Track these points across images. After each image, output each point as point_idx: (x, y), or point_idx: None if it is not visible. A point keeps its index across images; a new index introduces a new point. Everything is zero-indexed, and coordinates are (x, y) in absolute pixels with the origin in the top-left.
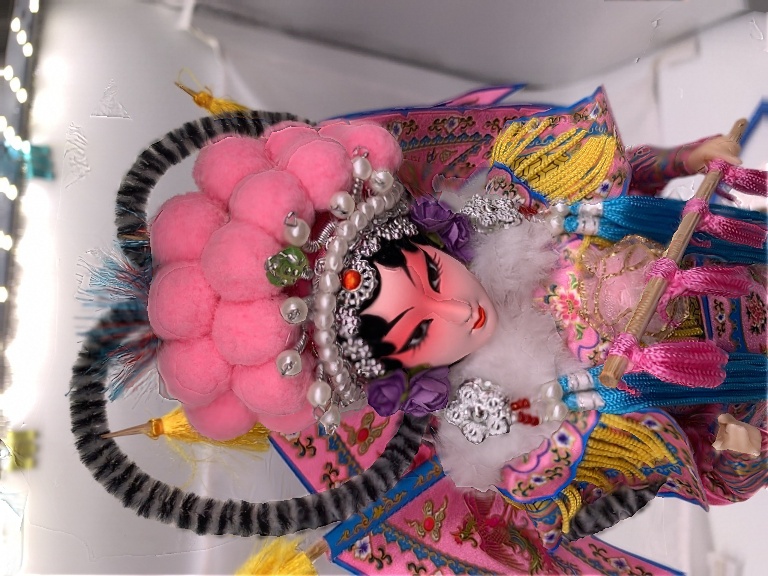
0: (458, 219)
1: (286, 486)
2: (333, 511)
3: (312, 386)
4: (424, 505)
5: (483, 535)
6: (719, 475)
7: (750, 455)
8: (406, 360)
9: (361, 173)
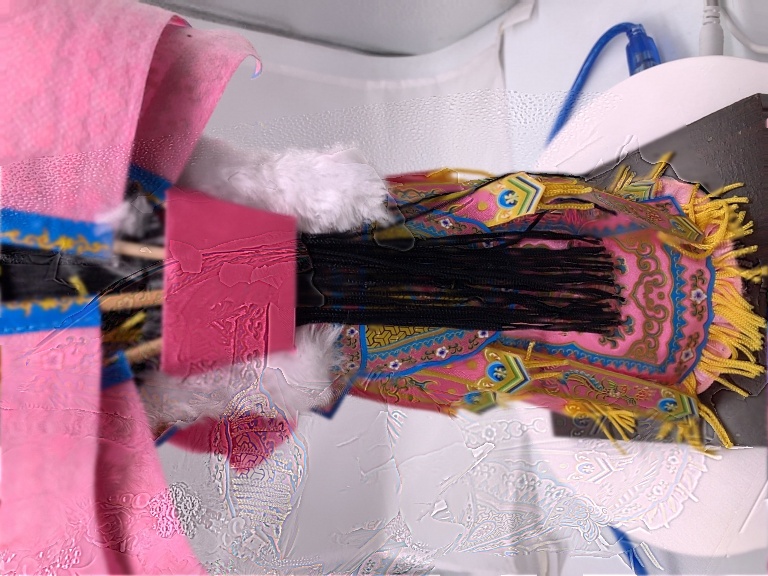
0: (131, 536)
1: None
2: None
3: None
4: None
5: None
6: None
7: None
8: None
9: (5, 572)
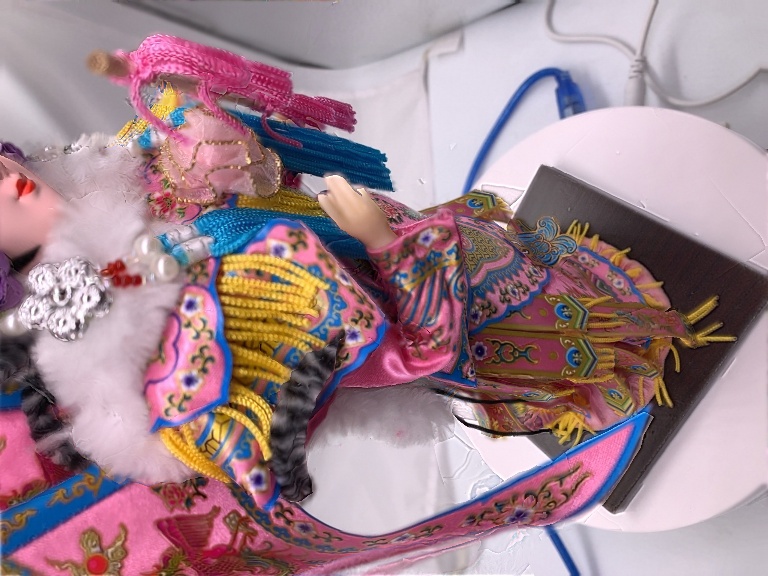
0: (5, 143)
1: None
2: None
3: None
4: (82, 537)
5: (200, 569)
6: (405, 320)
7: (395, 250)
8: None
9: None
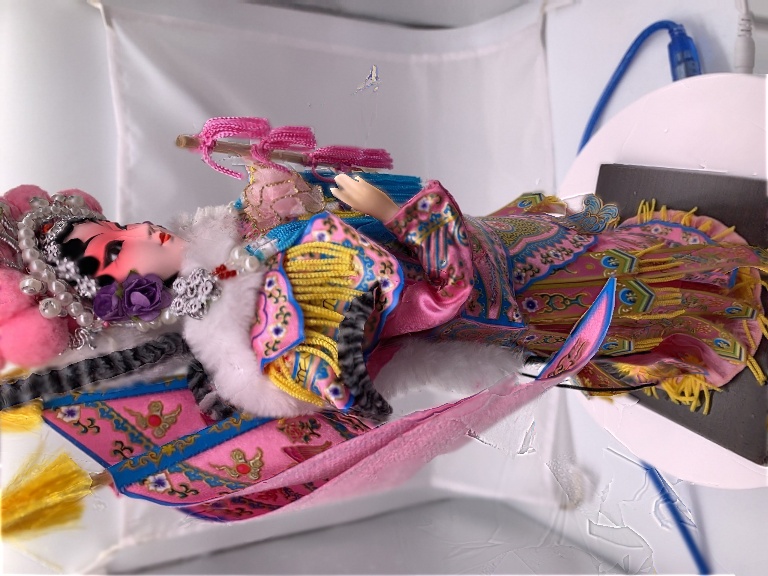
0: None
1: (65, 450)
2: (66, 373)
3: (23, 281)
4: (232, 454)
5: None
6: (427, 269)
7: (401, 217)
8: (116, 274)
9: (57, 199)
